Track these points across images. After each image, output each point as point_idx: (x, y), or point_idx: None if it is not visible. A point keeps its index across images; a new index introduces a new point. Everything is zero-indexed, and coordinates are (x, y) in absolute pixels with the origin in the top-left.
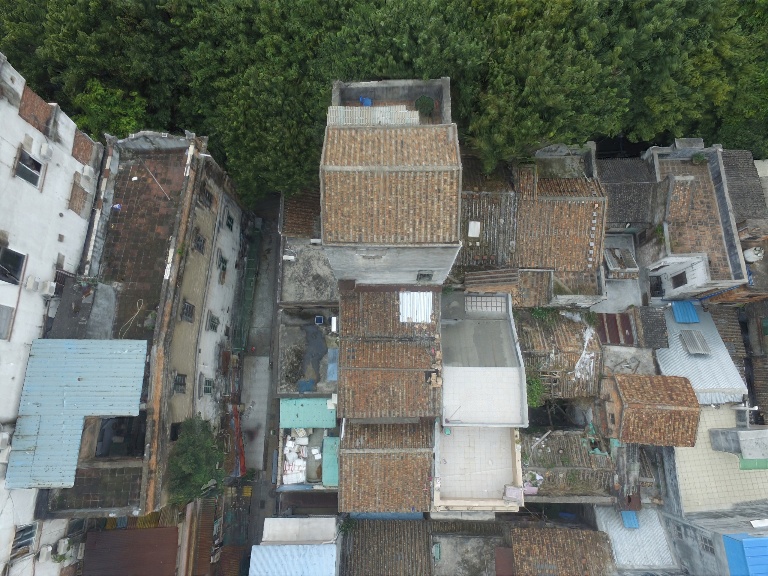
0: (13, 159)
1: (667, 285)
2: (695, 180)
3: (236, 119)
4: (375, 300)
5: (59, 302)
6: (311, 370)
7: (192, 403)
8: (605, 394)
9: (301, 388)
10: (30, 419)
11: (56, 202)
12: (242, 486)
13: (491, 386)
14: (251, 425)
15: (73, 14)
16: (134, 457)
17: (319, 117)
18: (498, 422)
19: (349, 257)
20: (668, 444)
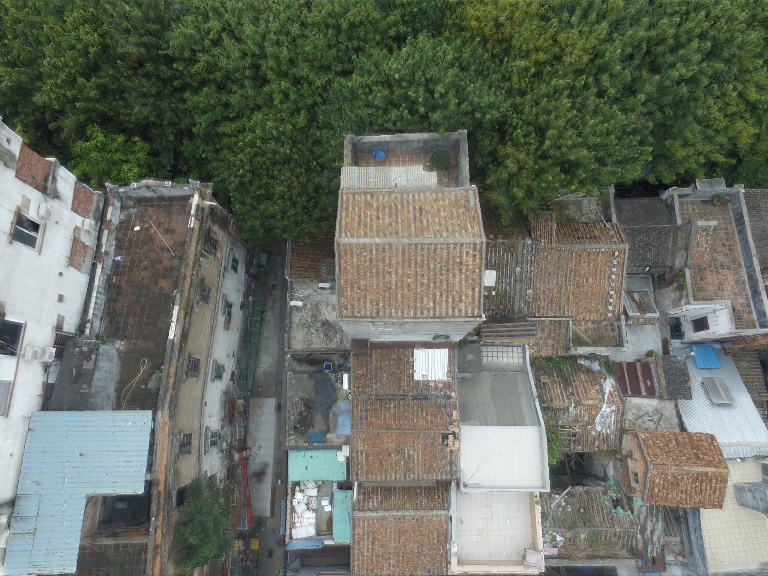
0: (10, 224)
1: (687, 328)
2: (718, 225)
3: (242, 166)
4: (388, 357)
5: (59, 365)
6: (320, 420)
7: (198, 461)
8: (627, 450)
9: (310, 439)
10: (29, 499)
11: (55, 261)
12: (249, 538)
13: (510, 446)
14: (257, 470)
15: (72, 60)
16: (139, 529)
17: (328, 165)
18: (518, 485)
19: (364, 326)
20: (695, 506)
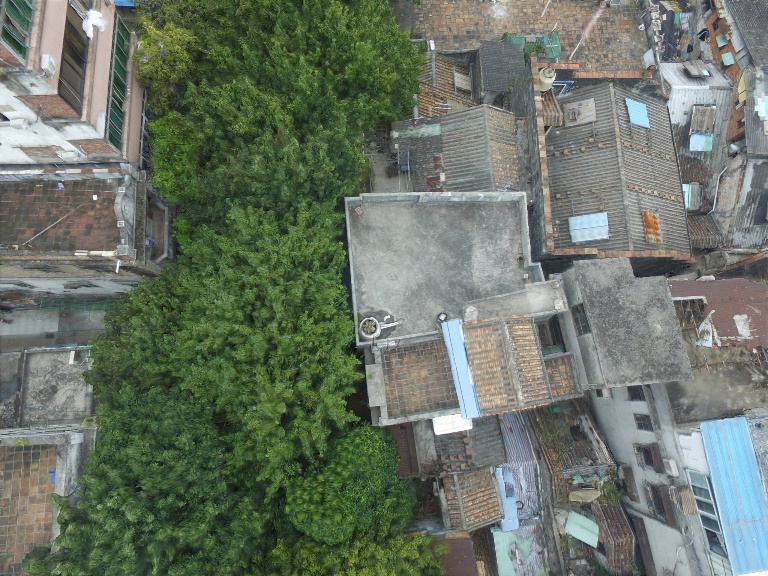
0: None
1: None
2: None
3: None
4: None
5: None
6: None
7: None
8: None
9: None
10: None
11: (2, 138)
12: None
13: None
14: None
15: (228, 111)
16: None
17: None
18: None
19: None
20: None
